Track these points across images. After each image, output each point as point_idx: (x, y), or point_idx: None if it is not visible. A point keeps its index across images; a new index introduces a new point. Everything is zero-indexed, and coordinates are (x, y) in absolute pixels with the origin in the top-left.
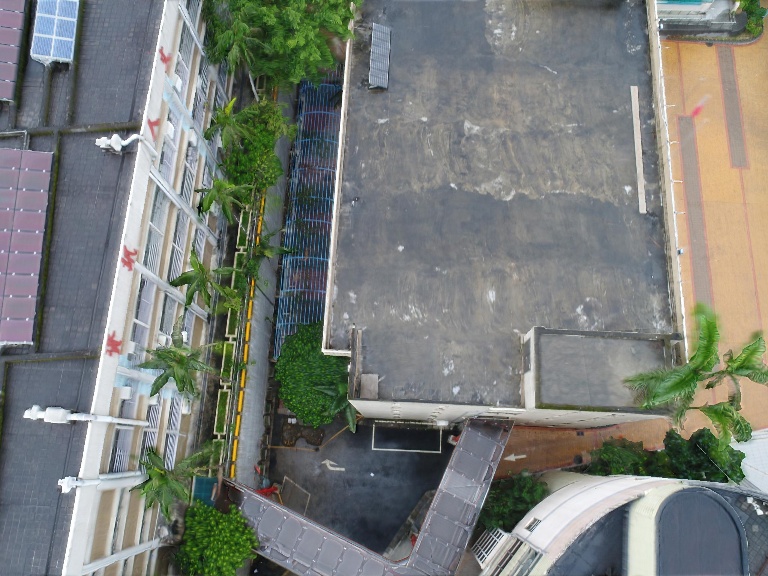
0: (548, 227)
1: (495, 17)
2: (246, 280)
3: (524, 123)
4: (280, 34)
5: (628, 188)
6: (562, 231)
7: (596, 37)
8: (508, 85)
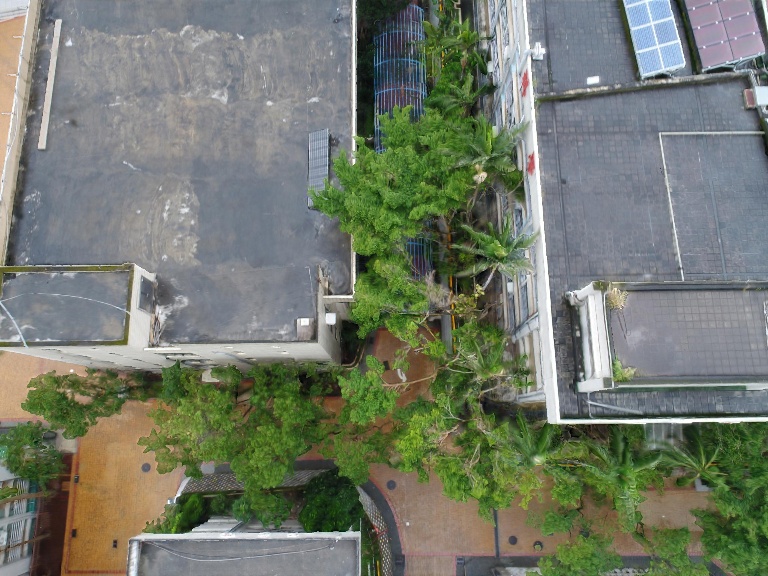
0: (152, 3)
1: (187, 229)
2: (445, 5)
3: (165, 103)
4: (424, 129)
5: (69, 44)
6: (139, 1)
7: (73, 209)
8: (178, 145)
